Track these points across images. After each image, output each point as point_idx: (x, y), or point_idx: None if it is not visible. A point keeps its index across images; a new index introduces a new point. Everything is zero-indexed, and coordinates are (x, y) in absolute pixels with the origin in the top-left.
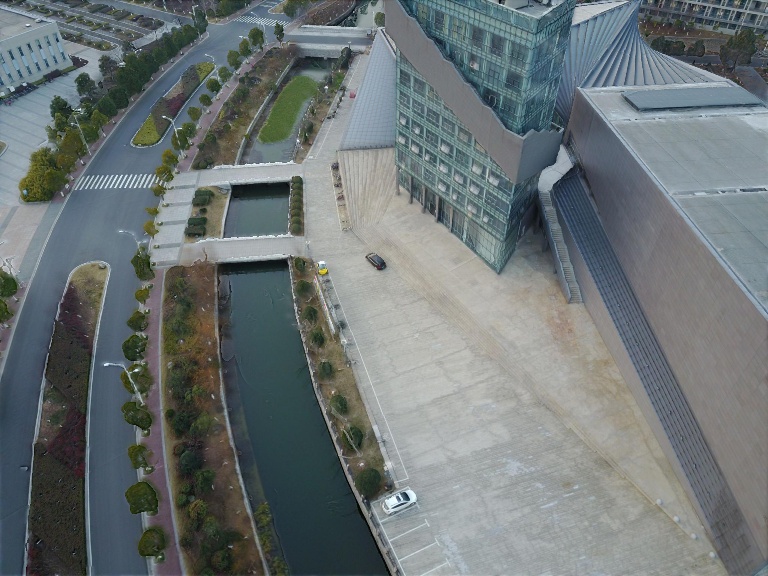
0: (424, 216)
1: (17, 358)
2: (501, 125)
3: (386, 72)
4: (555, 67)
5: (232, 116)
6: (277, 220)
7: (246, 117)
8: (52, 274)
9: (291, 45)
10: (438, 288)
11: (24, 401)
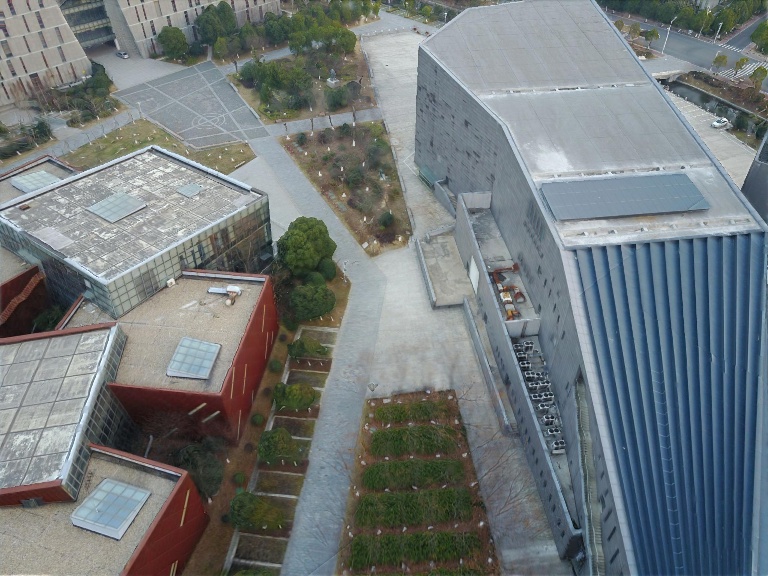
0: None
1: None
2: None
3: None
4: None
5: None
6: None
7: None
8: None
9: None
10: None
11: None
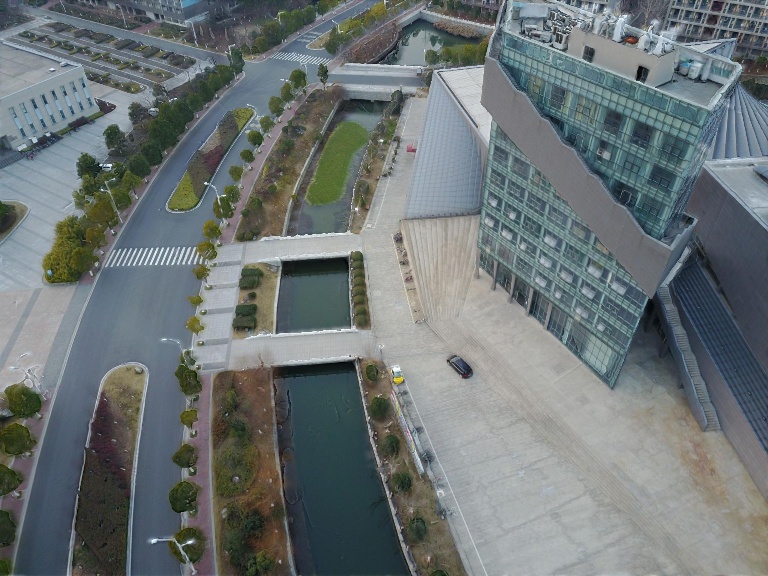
0: (511, 307)
1: (41, 500)
2: (639, 229)
3: (450, 126)
4: (704, 155)
5: (277, 173)
6: (336, 306)
7: (292, 174)
8: (81, 380)
9: (335, 87)
10: (541, 407)
11: (50, 565)
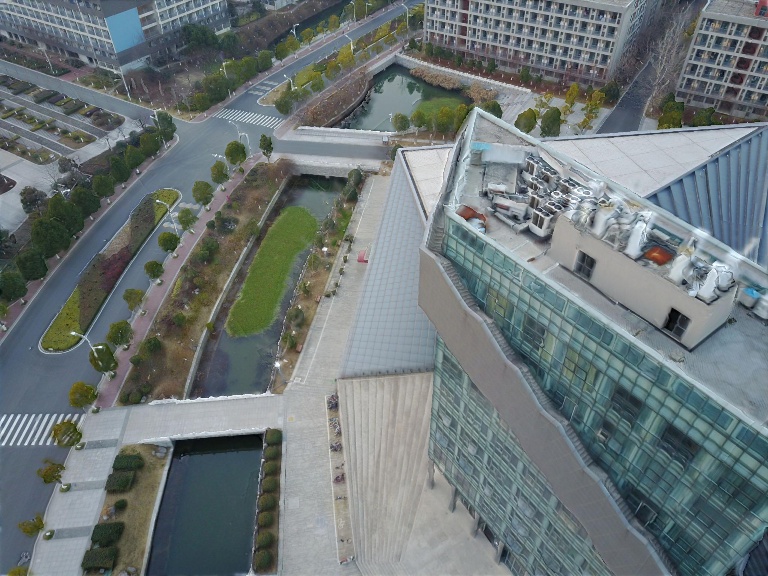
0: (476, 545)
1: None
2: None
3: (410, 237)
4: None
5: (191, 291)
6: (238, 518)
7: (211, 289)
8: None
9: (282, 160)
10: None
11: None
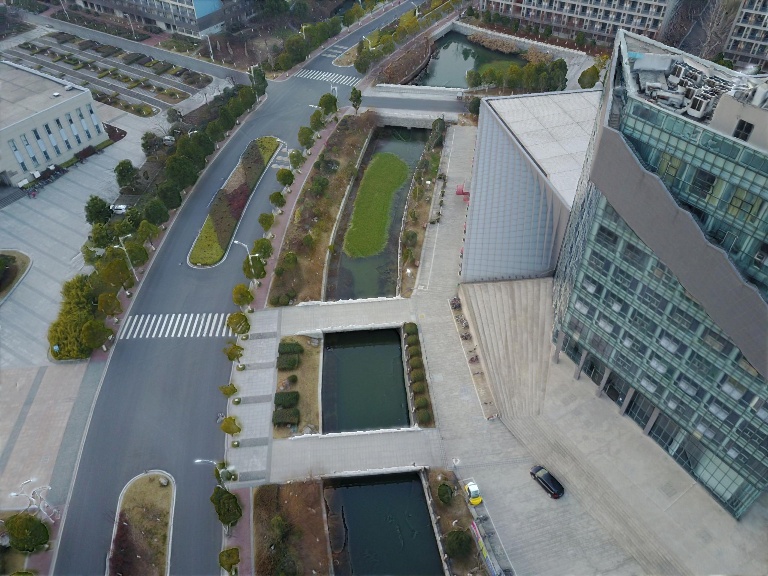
0: (601, 403)
1: None
2: None
3: (510, 169)
4: None
5: (311, 219)
6: (390, 391)
7: (327, 219)
8: (95, 495)
9: (368, 112)
10: (654, 544)
11: None
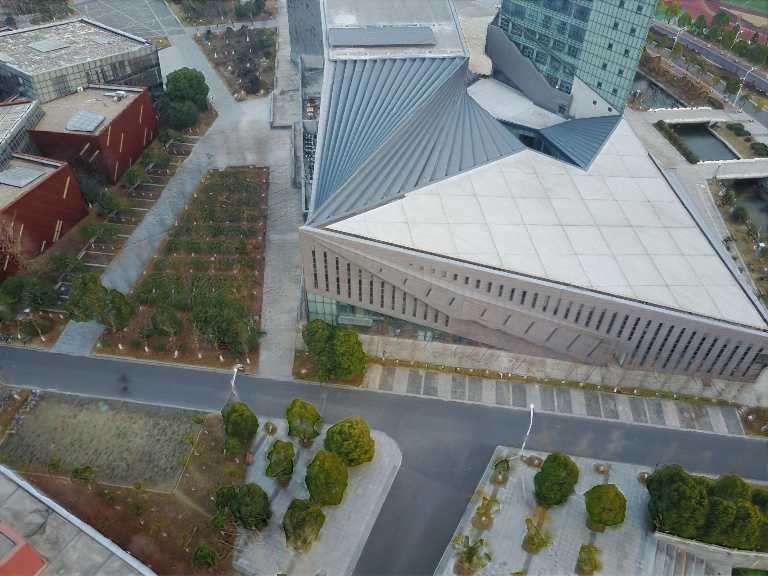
0: None
1: None
2: None
3: None
4: None
5: None
6: None
7: None
8: None
9: None
10: None
11: (726, 65)
